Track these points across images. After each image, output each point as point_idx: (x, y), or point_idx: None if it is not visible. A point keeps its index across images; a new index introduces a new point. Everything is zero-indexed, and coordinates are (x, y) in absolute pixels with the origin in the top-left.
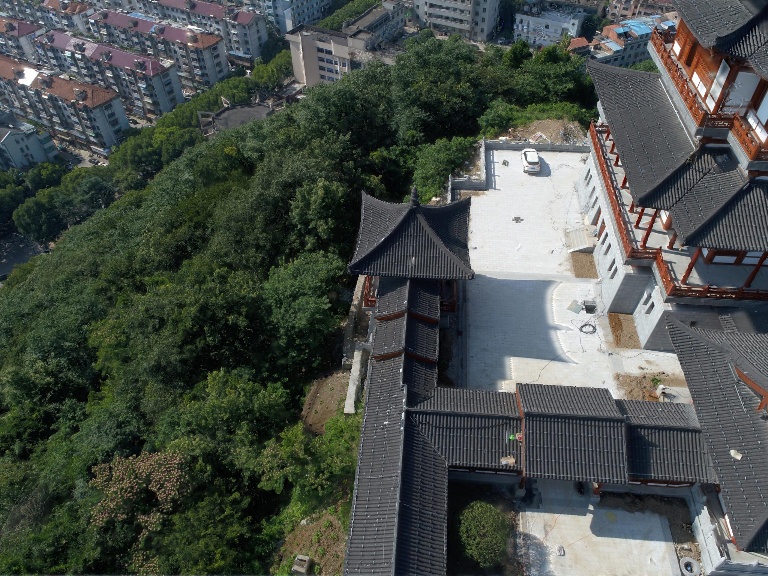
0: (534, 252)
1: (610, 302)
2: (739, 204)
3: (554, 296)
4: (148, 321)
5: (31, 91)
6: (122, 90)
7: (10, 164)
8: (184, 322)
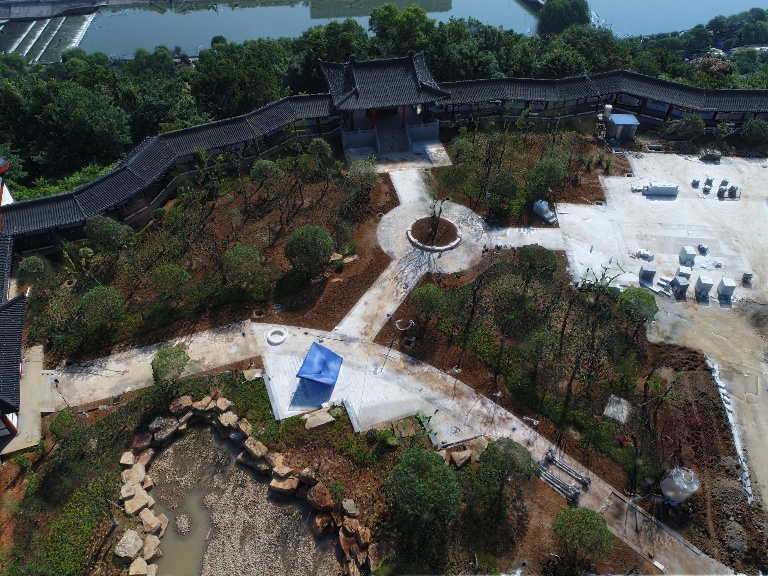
0: None
1: None
2: None
3: None
4: None
5: None
6: None
7: None
8: None
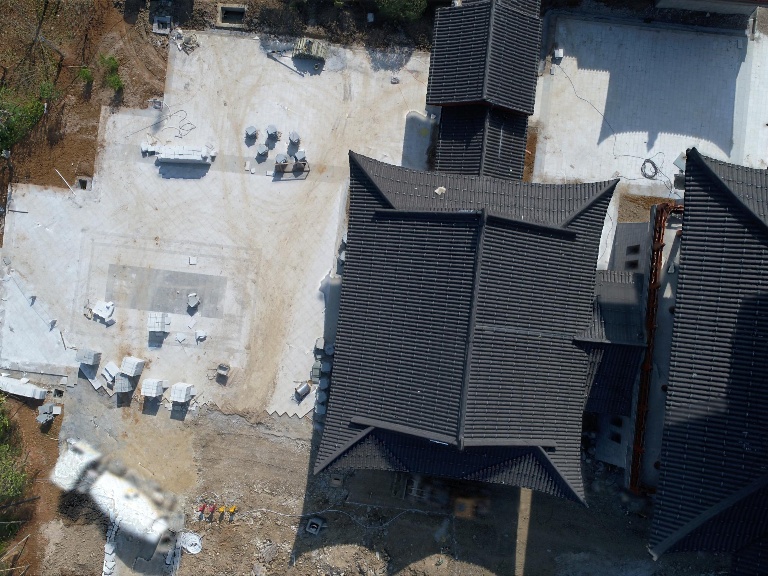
0: None
1: None
2: (763, 246)
3: (704, 141)
4: None
5: None
6: None
7: None
8: None
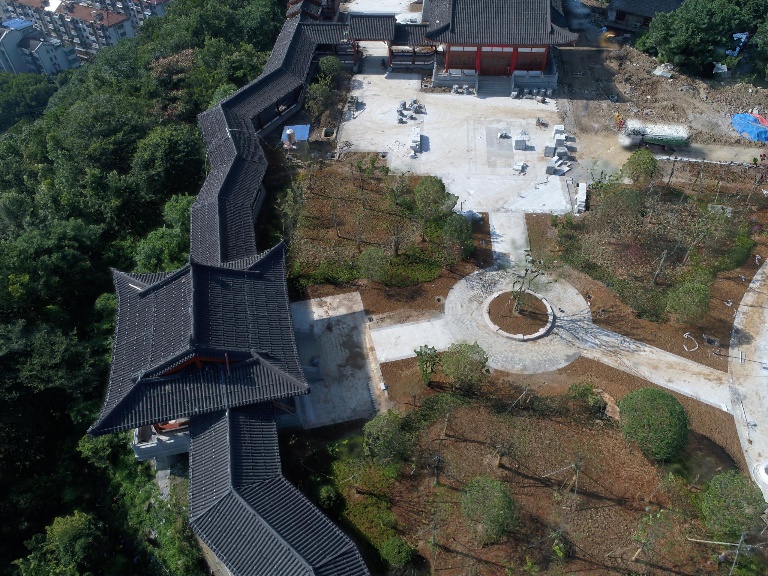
0: (390, 4)
1: (422, 15)
2: None
3: None
4: (172, 33)
5: (56, 16)
6: (130, 20)
7: (42, 71)
8: (192, 26)
